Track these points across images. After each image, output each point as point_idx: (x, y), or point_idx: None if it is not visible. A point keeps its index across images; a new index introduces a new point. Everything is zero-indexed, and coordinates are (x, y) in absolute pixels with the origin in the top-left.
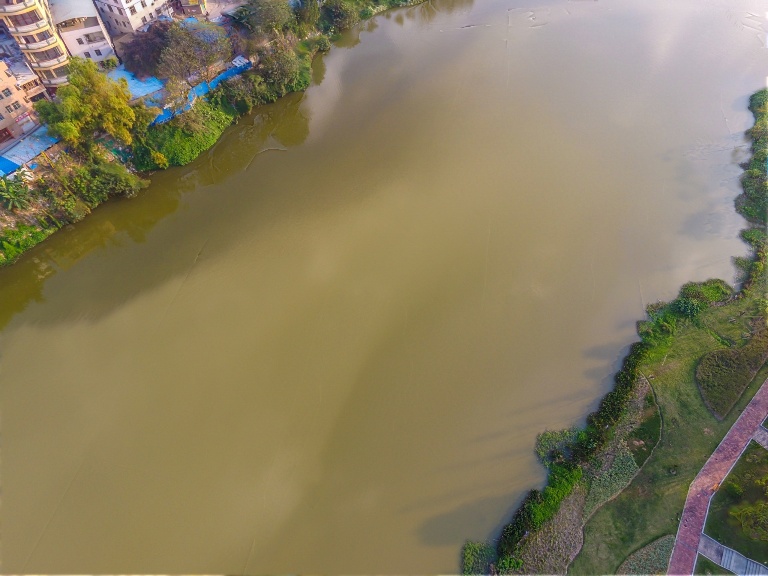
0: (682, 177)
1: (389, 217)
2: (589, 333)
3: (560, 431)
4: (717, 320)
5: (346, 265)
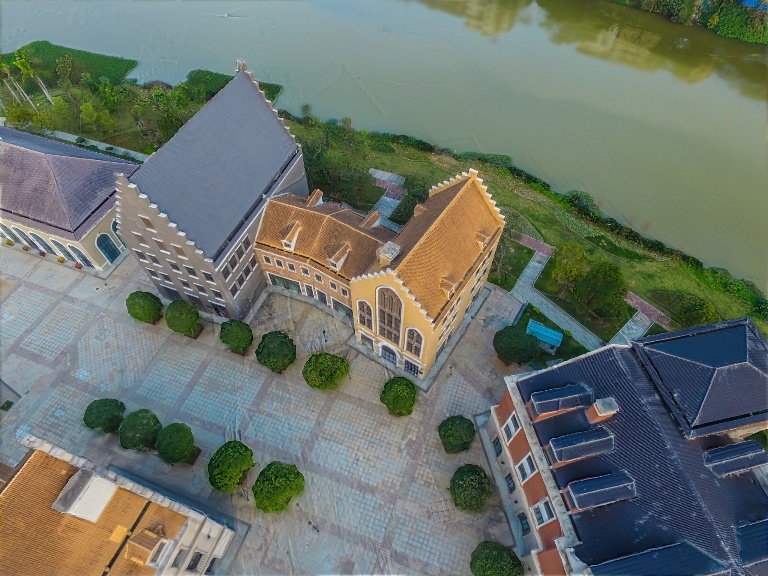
0: None
1: (742, 127)
2: (693, 235)
3: (595, 204)
4: (767, 332)
5: (677, 107)
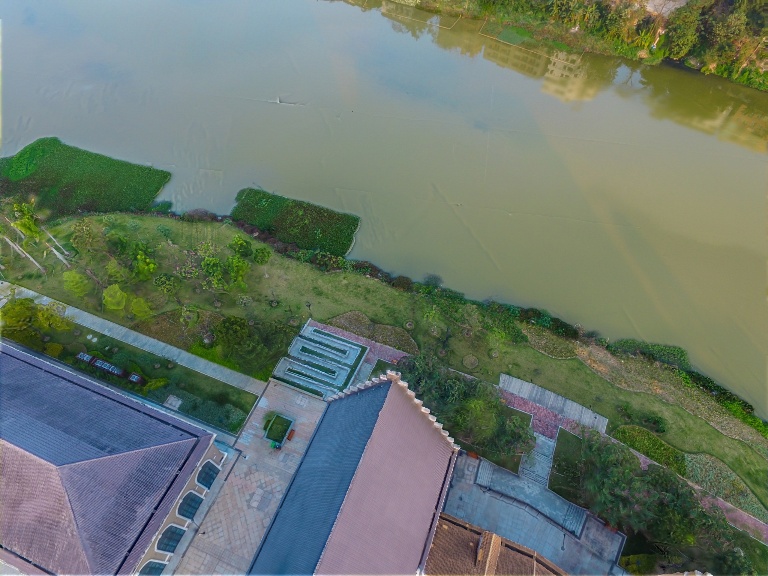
0: None
1: None
2: None
3: None
4: None
5: None
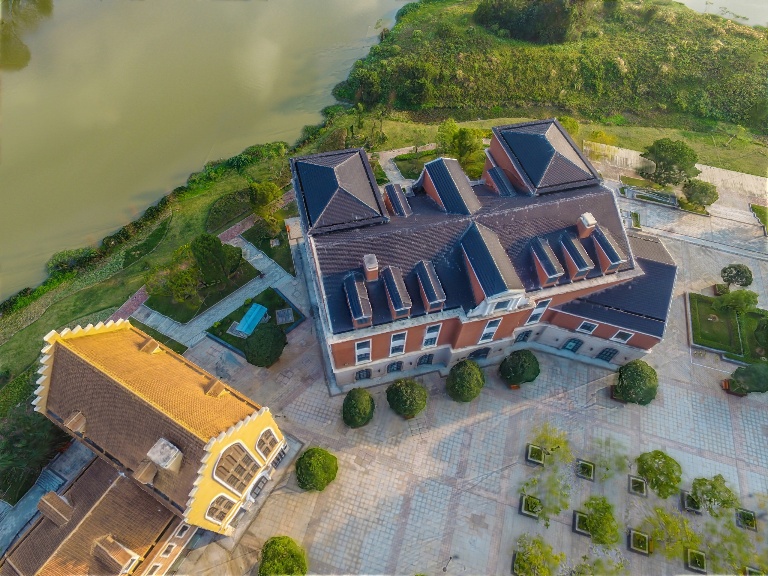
0: (302, 70)
1: (16, 107)
2: (146, 183)
3: (76, 250)
4: (259, 169)
5: None
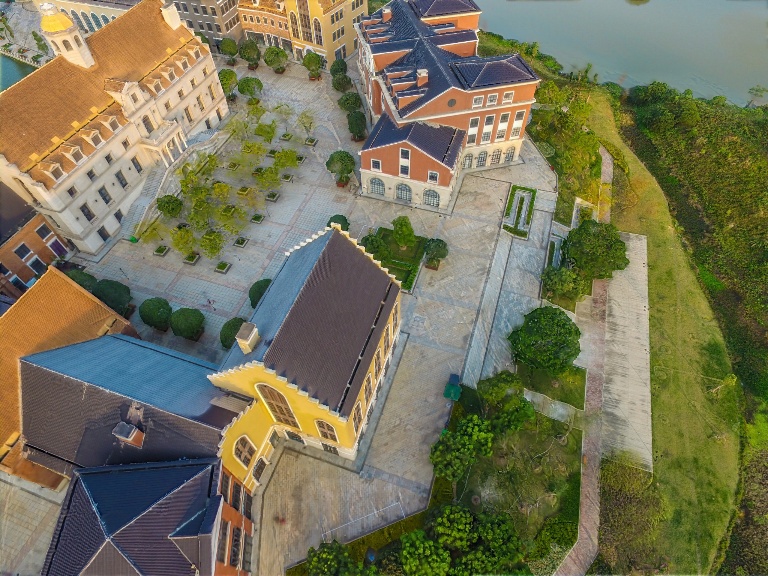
0: (664, 71)
1: None
2: (504, 28)
3: None
4: None
5: None
